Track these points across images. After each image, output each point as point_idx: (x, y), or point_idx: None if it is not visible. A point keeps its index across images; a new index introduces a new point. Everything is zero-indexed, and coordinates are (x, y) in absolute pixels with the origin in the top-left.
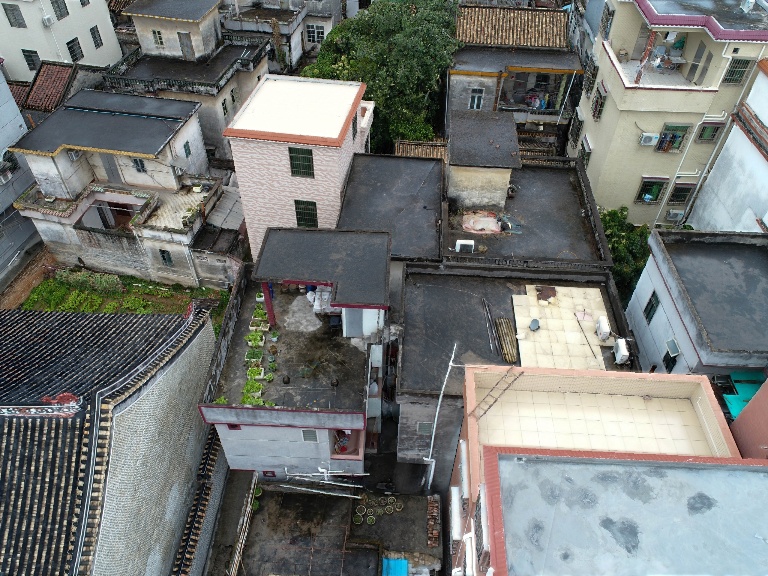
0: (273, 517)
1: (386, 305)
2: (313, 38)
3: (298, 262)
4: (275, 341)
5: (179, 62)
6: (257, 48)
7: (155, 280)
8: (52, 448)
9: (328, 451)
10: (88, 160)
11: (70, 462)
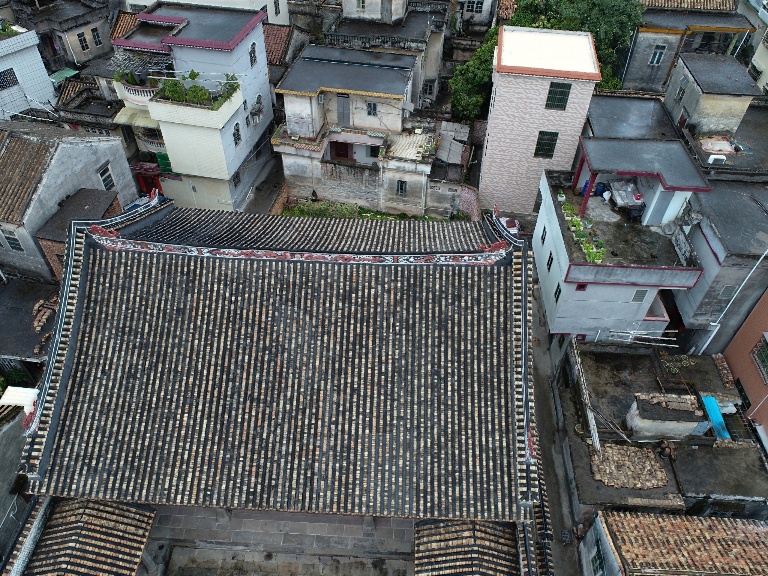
0: (593, 368)
1: (711, 188)
2: (472, 8)
3: (621, 160)
4: (589, 228)
5: (377, 24)
6: (440, 13)
7: (382, 210)
8: (477, 289)
9: (645, 312)
10: (324, 105)
11: (493, 299)
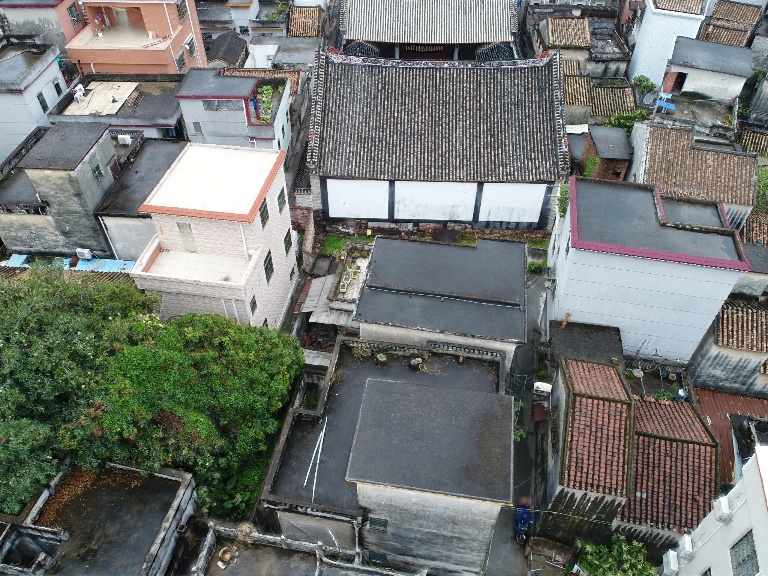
0: None
1: None
2: None
3: (233, 83)
4: None
5: None
6: None
7: None
8: None
9: None
10: None
11: None
